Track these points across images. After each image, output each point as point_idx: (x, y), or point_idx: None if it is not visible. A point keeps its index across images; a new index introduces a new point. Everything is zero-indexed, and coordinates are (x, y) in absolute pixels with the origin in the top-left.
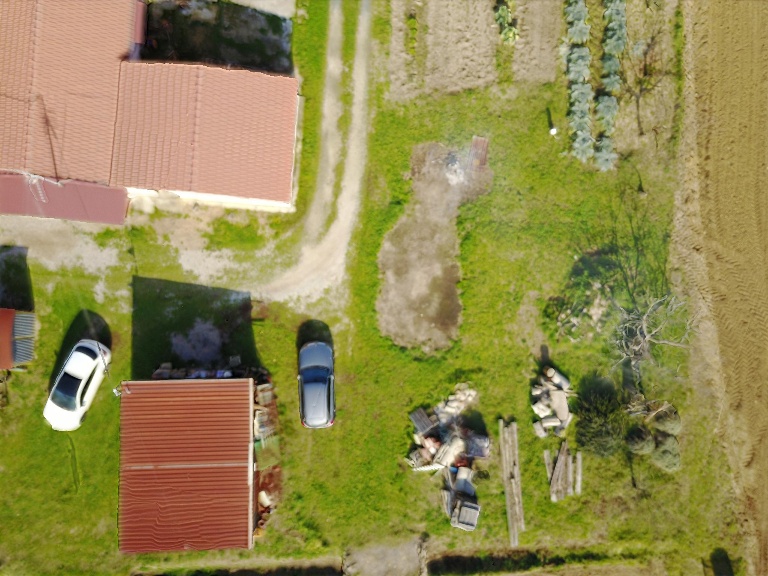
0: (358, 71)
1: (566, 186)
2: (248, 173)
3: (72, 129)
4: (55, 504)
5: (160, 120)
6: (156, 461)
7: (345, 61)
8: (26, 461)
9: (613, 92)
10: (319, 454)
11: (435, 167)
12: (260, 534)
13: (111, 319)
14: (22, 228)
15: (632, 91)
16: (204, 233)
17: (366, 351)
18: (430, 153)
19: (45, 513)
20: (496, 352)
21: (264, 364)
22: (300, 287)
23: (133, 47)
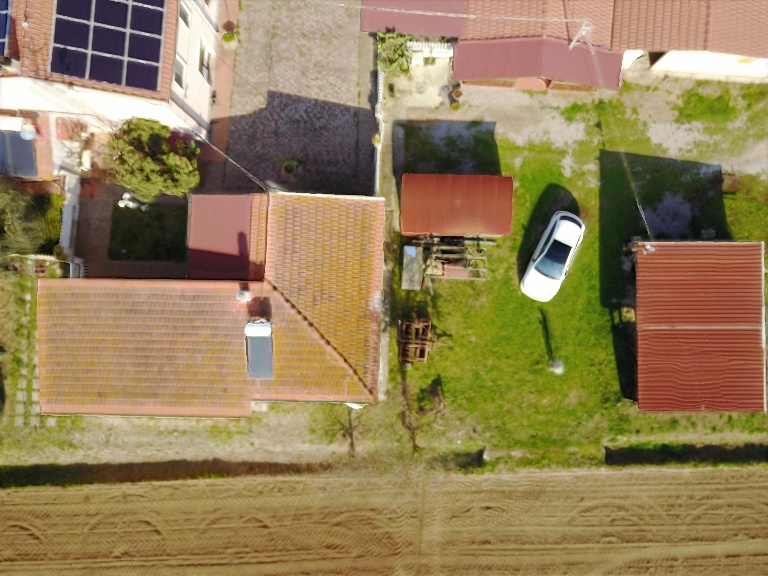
0: None
1: None
2: (759, 33)
3: None
4: (527, 374)
5: None
6: (674, 321)
7: None
8: (497, 332)
9: None
10: None
11: None
12: None
13: (578, 193)
14: (489, 103)
15: None
16: (673, 106)
17: None
18: None
19: (517, 382)
20: None
21: (735, 238)
22: None
23: None
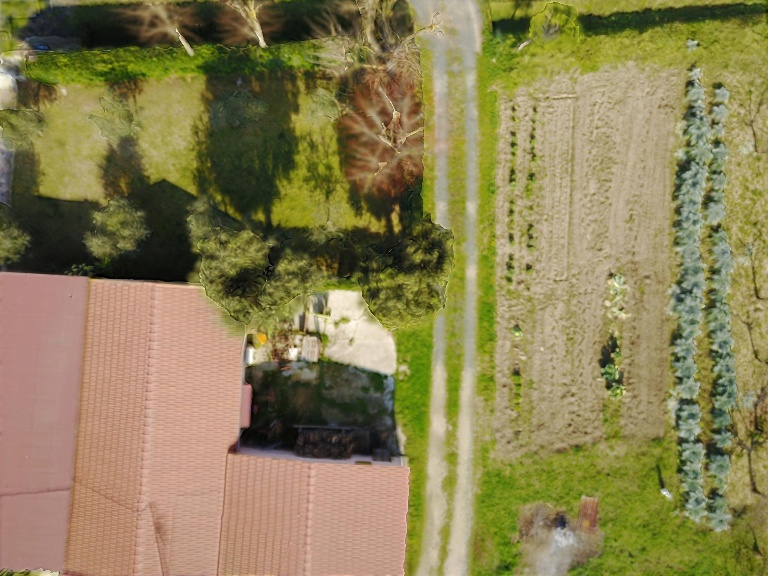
0: (462, 429)
1: (679, 547)
2: (360, 571)
3: (179, 531)
4: None
5: (270, 518)
6: None
7: (448, 419)
8: None
9: (724, 446)
10: None
11: (543, 528)
12: None
13: None
14: None
15: (743, 444)
16: None
17: None
18: (538, 514)
19: None
20: None
21: None
22: None
23: (238, 433)
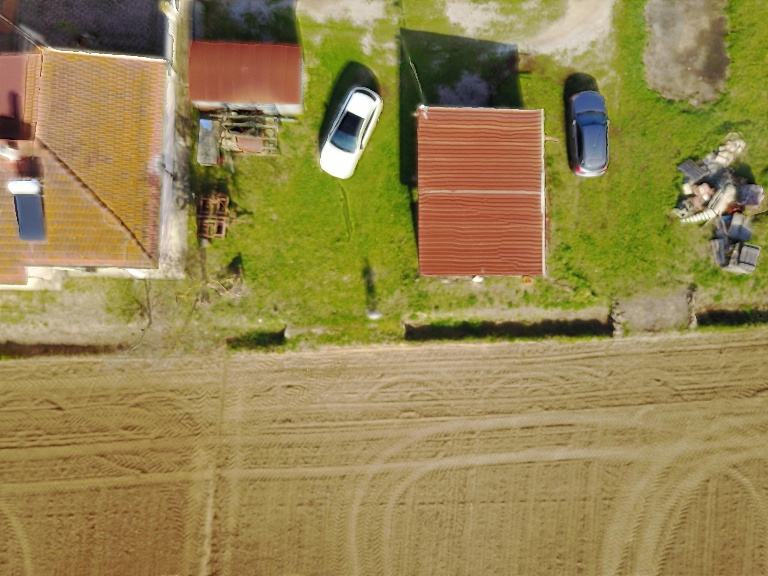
0: None
1: None
2: None
3: None
4: (328, 251)
5: None
6: (454, 185)
7: None
8: (299, 210)
9: None
10: (587, 206)
11: None
12: (532, 281)
13: (379, 71)
14: None
15: None
16: None
17: (634, 104)
18: None
19: (318, 260)
20: (765, 105)
21: None
22: (567, 40)
23: None
